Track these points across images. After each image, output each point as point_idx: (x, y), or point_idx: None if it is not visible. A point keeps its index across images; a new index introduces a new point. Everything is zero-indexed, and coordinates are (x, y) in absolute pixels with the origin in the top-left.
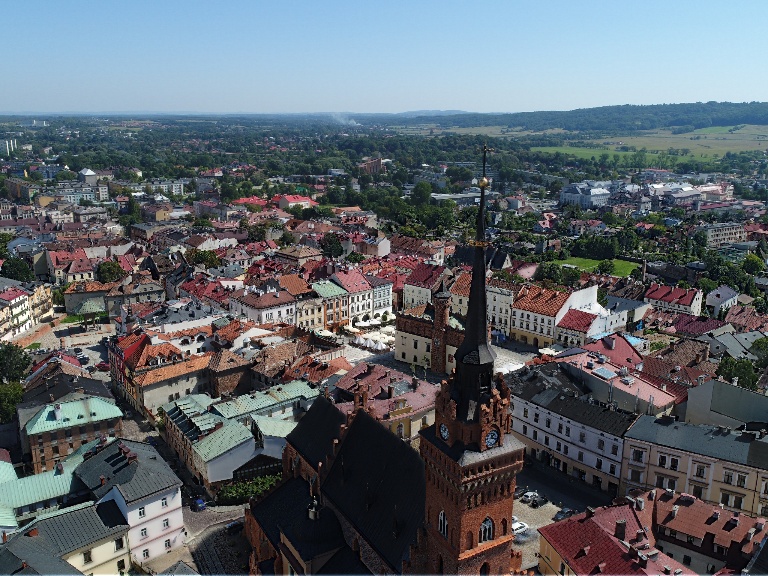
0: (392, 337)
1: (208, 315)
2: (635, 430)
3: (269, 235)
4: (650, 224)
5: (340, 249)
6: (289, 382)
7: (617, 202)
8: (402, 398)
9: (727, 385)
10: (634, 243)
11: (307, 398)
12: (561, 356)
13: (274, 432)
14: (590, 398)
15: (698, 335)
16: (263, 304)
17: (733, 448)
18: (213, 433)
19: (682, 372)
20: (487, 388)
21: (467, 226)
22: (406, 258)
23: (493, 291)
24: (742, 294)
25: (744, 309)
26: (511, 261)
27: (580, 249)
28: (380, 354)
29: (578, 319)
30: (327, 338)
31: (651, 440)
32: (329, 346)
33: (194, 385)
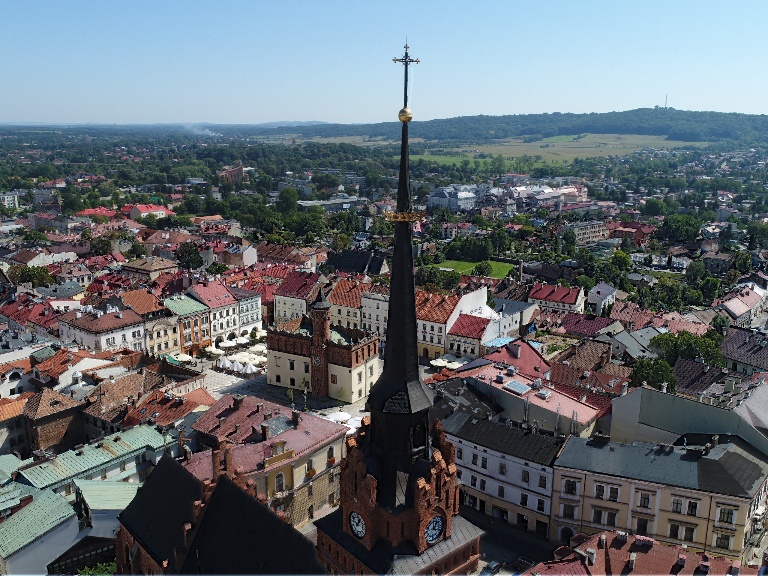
0: (263, 357)
1: (25, 345)
2: (565, 456)
3: (116, 247)
4: (519, 225)
5: (199, 260)
6: (130, 428)
7: (484, 205)
8: (280, 440)
9: (657, 393)
10: (507, 244)
11: (155, 448)
12: (463, 369)
13: (106, 503)
14: (507, 420)
15: (597, 335)
16: (101, 327)
17: (680, 470)
18: (17, 512)
19: (592, 378)
20: (422, 449)
21: (337, 232)
22: (275, 266)
23: (376, 298)
24: (617, 290)
25: (627, 305)
26: (388, 266)
27: (455, 252)
28: (250, 378)
29: (470, 325)
30: (185, 363)
31: (586, 467)
32: (185, 375)
33: (4, 439)
